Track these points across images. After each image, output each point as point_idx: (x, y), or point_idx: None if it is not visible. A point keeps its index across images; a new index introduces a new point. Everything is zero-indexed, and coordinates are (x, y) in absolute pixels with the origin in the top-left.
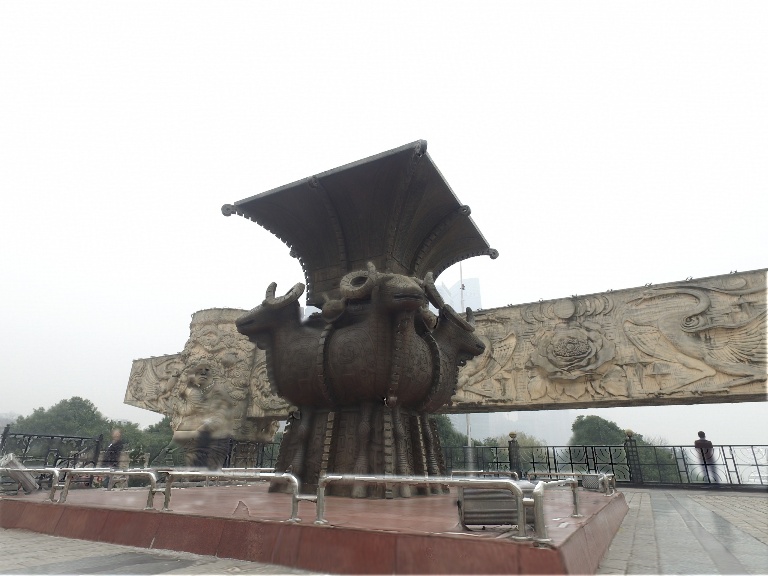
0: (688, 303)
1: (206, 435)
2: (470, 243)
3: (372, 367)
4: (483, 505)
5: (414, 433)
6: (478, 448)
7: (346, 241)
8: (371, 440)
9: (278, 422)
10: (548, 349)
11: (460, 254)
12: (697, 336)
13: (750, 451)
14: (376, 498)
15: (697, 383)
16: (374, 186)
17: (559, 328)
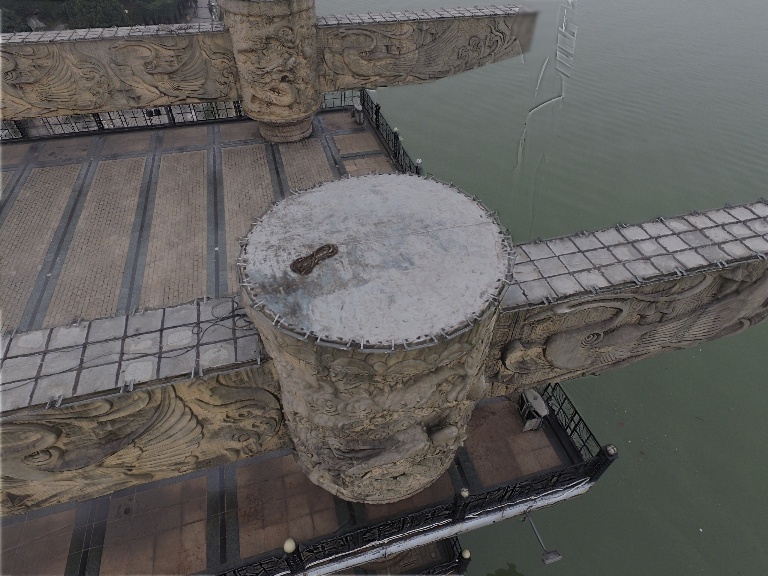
0: (2, 62)
1: None
2: None
3: None
4: None
5: None
6: None
7: None
8: None
9: None
10: None
11: None
12: (14, 86)
13: (81, 115)
14: None
15: (24, 112)
16: None
17: None
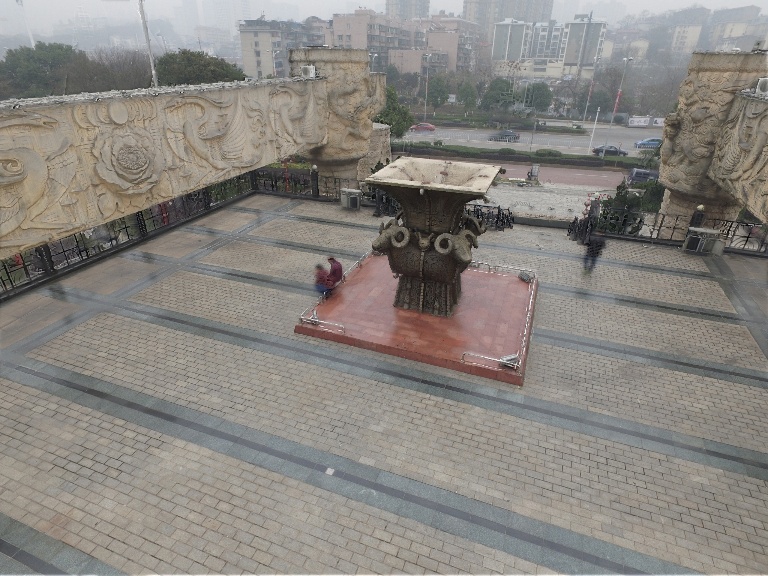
0: None
1: None
2: None
3: None
4: None
5: None
6: None
7: None
8: None
9: None
10: None
11: (468, 198)
12: None
13: None
14: None
15: None
16: None
17: None
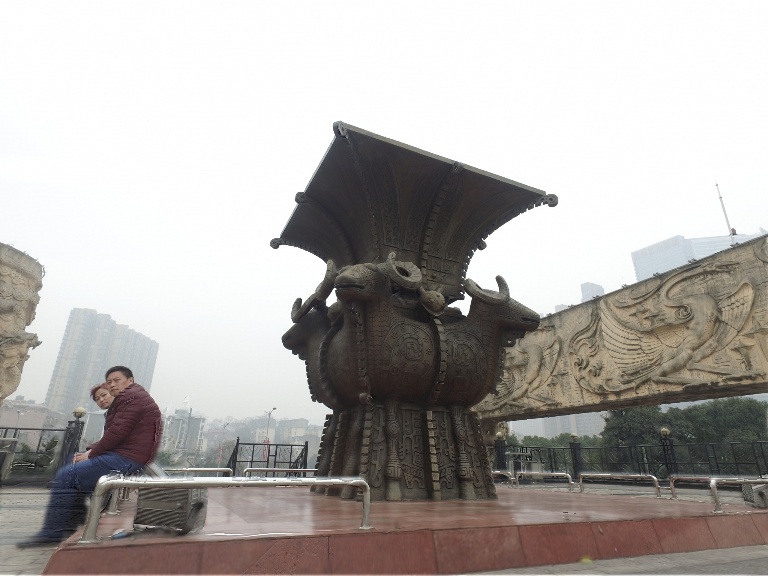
0: None
1: (113, 441)
2: (508, 198)
3: (347, 365)
4: (150, 504)
5: (425, 430)
6: (753, 444)
7: (351, 242)
8: (361, 439)
9: (506, 423)
10: None
11: (503, 214)
12: None
13: None
14: (354, 500)
15: None
16: (342, 182)
17: None
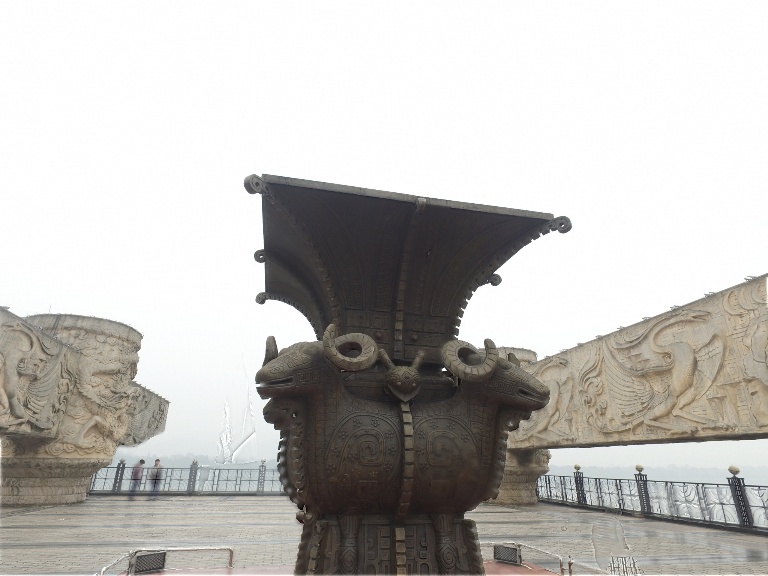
0: None
1: None
2: None
3: None
4: None
5: None
6: None
7: None
8: None
9: None
10: None
11: None
12: None
13: None
14: None
15: None
16: None
17: None
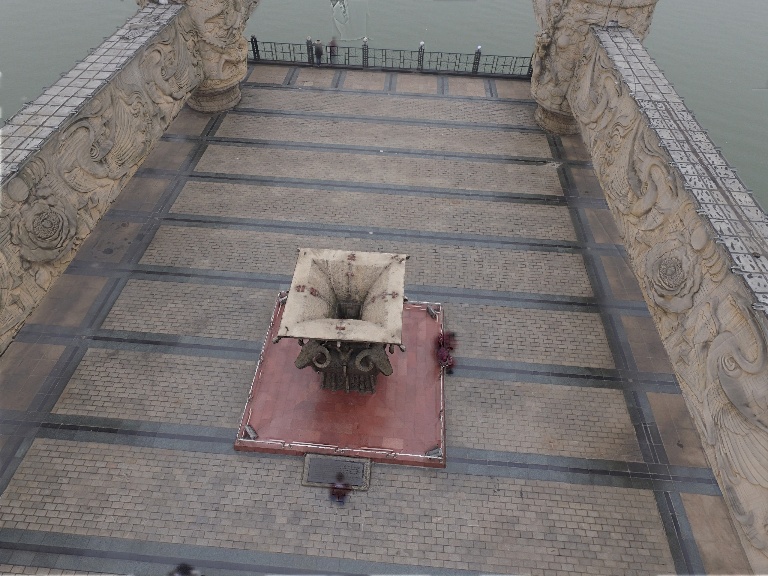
0: (83, 135)
1: None
2: None
3: None
4: None
5: None
6: None
7: None
8: None
9: None
10: (33, 239)
11: None
12: (101, 161)
13: None
14: None
15: None
16: None
17: (24, 212)
